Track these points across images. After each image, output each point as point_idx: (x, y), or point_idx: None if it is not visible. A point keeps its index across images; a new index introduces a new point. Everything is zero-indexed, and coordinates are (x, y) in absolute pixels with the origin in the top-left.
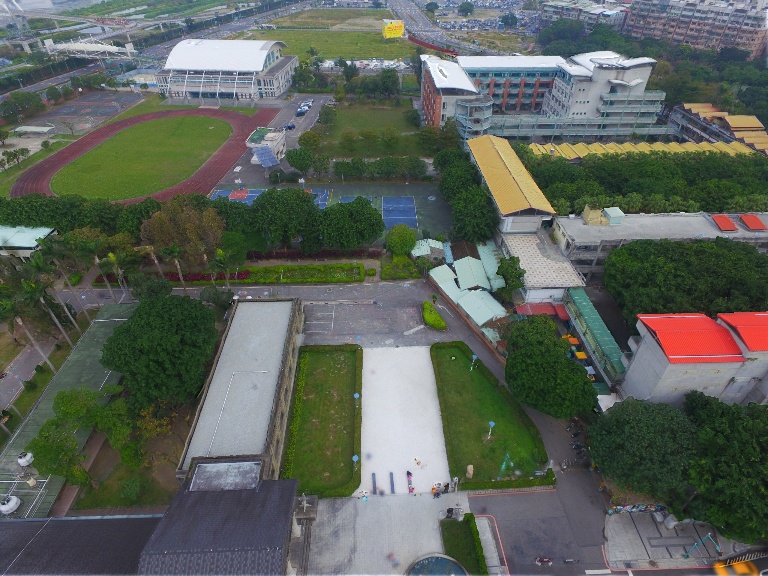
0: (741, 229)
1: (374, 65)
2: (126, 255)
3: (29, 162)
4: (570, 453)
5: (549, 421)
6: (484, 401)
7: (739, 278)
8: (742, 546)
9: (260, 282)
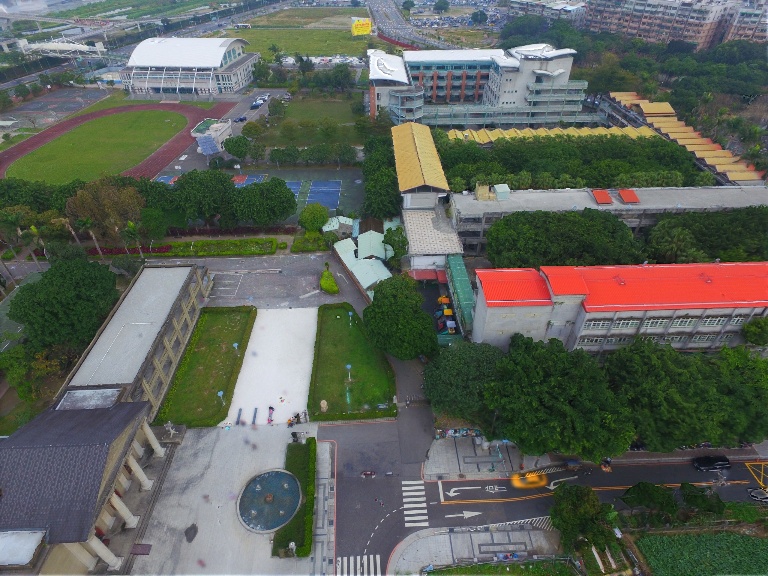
0: (617, 202)
1: (328, 60)
2: (47, 227)
3: None
4: (418, 392)
5: (408, 367)
6: (355, 351)
7: (589, 242)
8: (543, 463)
9: (179, 255)
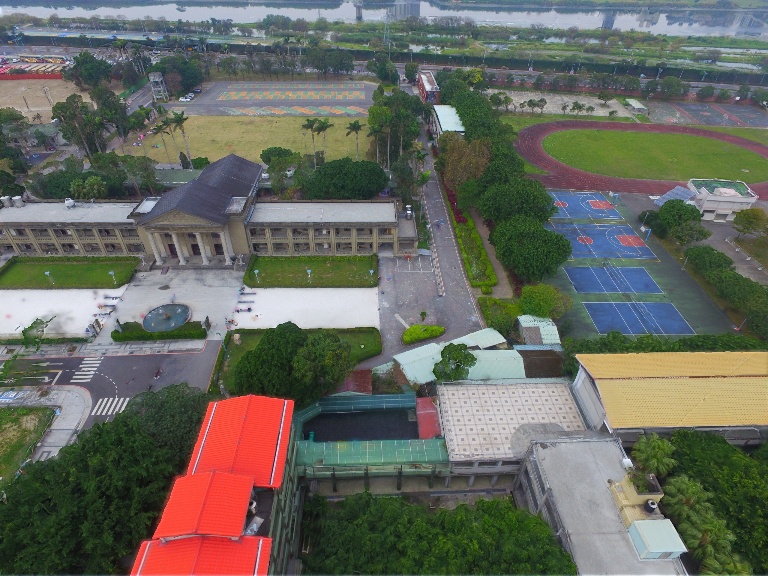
0: None
1: None
2: None
3: (587, 118)
4: None
5: None
6: None
7: None
8: None
9: None
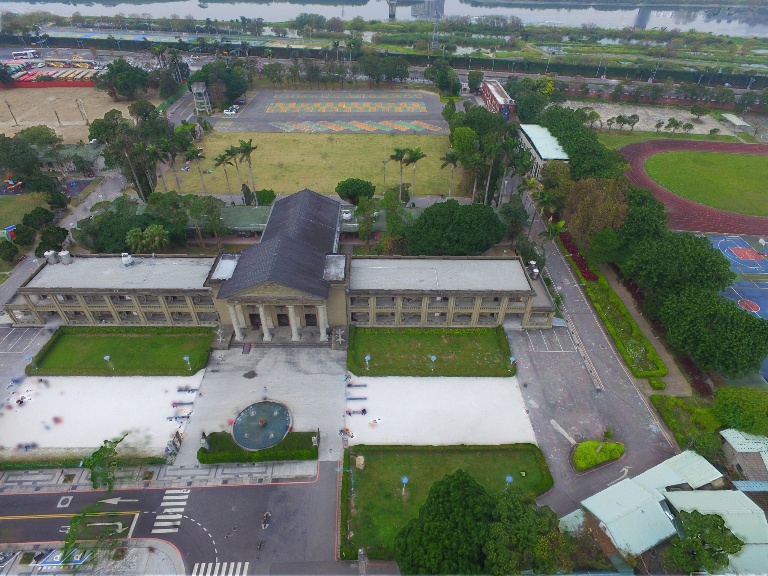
0: None
1: None
2: None
3: (683, 136)
4: None
5: None
6: None
7: None
8: None
9: (586, 289)
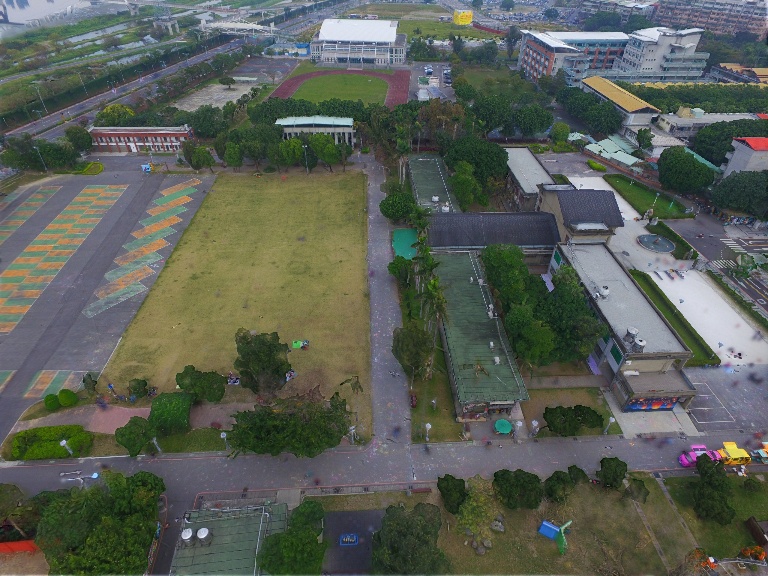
0: None
1: (477, 39)
2: None
3: (260, 98)
4: None
5: (682, 201)
6: (644, 195)
7: None
8: None
9: None
